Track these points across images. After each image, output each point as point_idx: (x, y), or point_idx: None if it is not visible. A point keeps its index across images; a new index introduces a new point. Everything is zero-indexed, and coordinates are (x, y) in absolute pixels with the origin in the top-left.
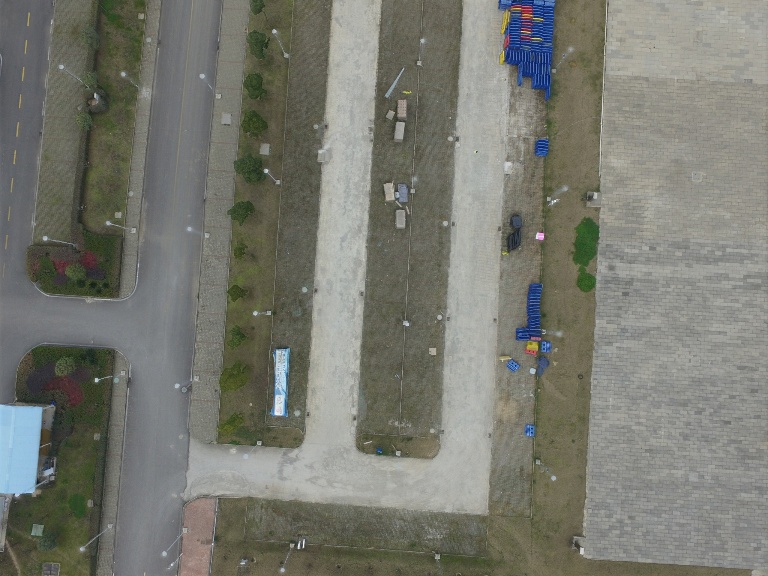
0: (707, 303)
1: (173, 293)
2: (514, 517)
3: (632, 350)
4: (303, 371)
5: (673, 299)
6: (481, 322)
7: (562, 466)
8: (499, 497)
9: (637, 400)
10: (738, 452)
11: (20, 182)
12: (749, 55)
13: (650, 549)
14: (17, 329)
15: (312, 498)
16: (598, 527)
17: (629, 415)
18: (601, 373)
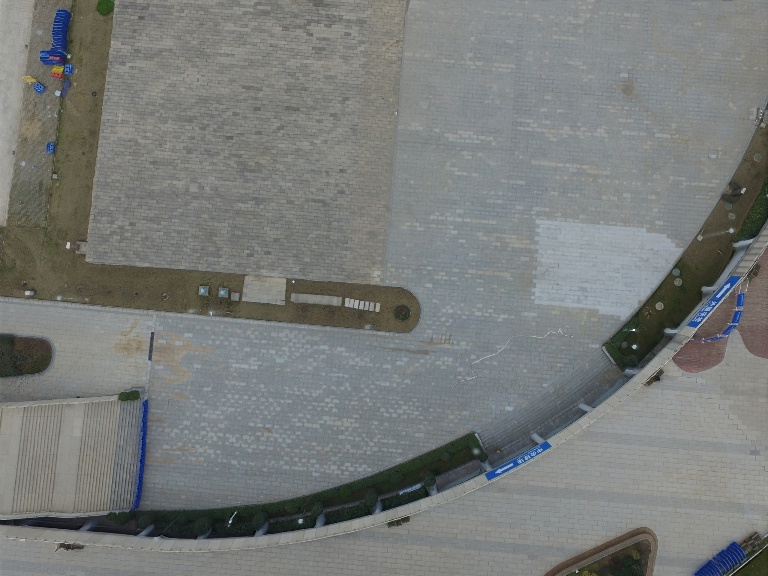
0: (218, 27)
1: None
2: (30, 228)
3: (144, 69)
4: None
5: (186, 23)
6: (13, 48)
7: (72, 177)
8: (18, 209)
9: (145, 115)
10: (238, 165)
11: None
12: None
13: (148, 254)
14: None
15: None
16: (100, 232)
17: (136, 129)
18: (112, 90)
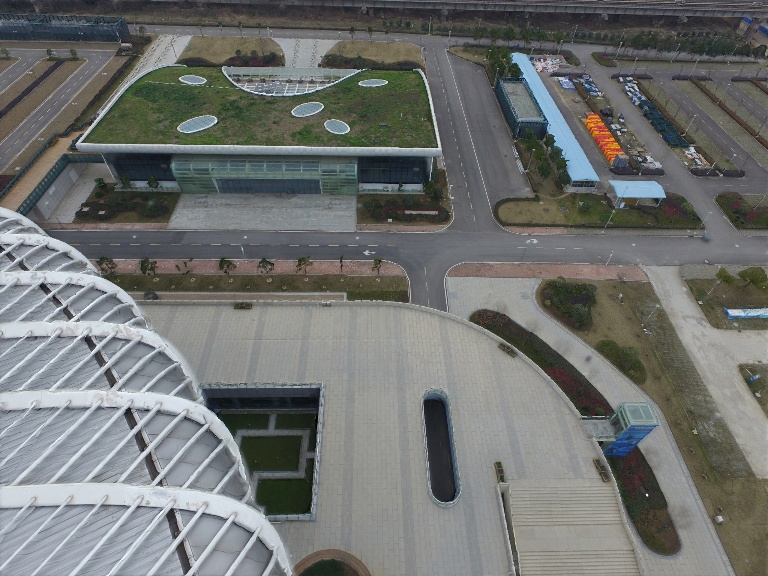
0: None
1: (761, 253)
2: None
3: None
4: (767, 326)
5: None
6: None
7: None
8: None
9: None
10: None
11: (765, 189)
12: None
13: None
14: (686, 191)
15: (682, 337)
16: None
17: None
18: None
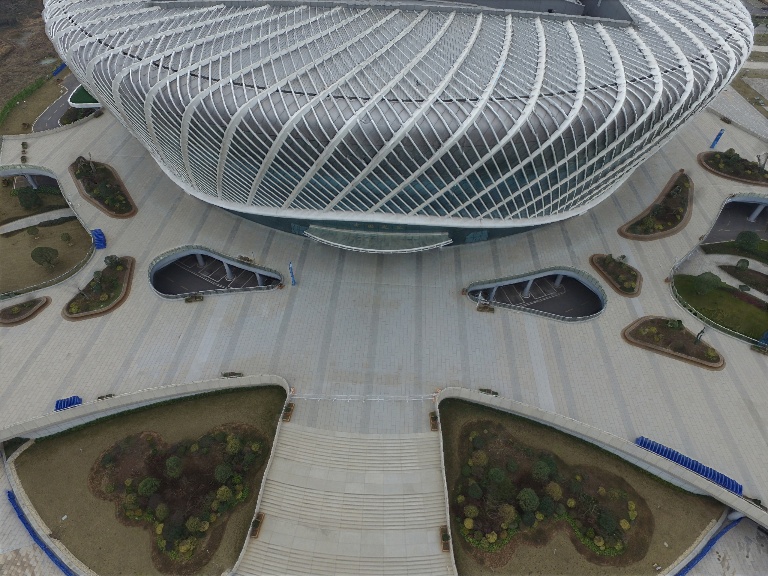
0: None
1: None
2: None
3: None
4: None
5: None
6: None
7: None
8: (742, 69)
9: None
10: None
11: None
12: None
13: None
14: None
15: None
16: None
17: None
18: None
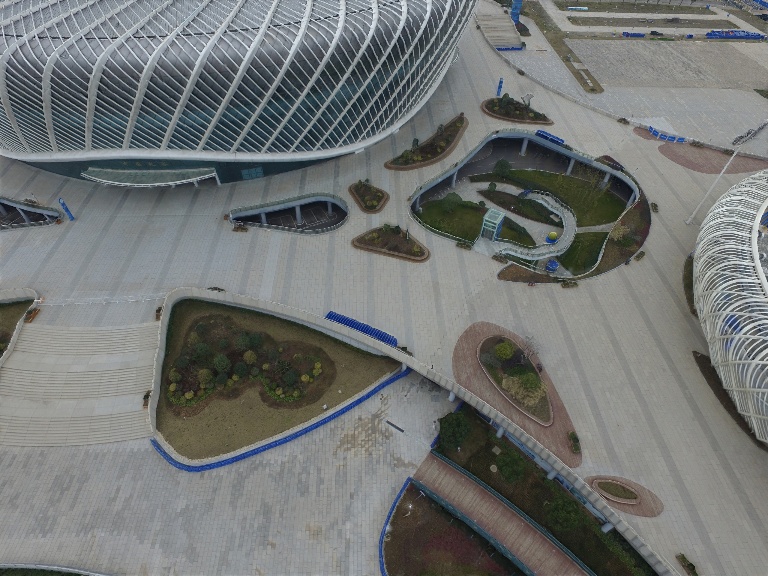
0: None
1: None
2: None
3: None
4: None
5: None
6: None
7: None
8: (569, 32)
9: None
10: None
11: None
12: (767, 62)
13: (574, 47)
14: None
15: None
16: None
17: None
18: None
